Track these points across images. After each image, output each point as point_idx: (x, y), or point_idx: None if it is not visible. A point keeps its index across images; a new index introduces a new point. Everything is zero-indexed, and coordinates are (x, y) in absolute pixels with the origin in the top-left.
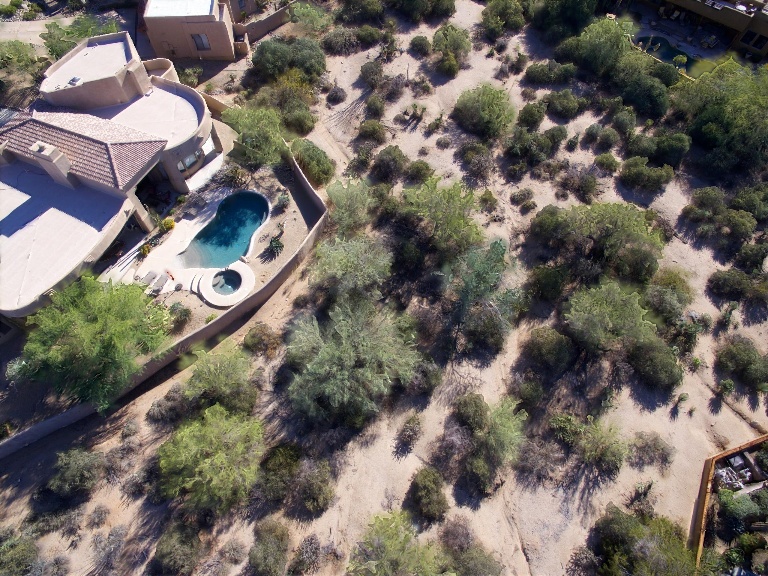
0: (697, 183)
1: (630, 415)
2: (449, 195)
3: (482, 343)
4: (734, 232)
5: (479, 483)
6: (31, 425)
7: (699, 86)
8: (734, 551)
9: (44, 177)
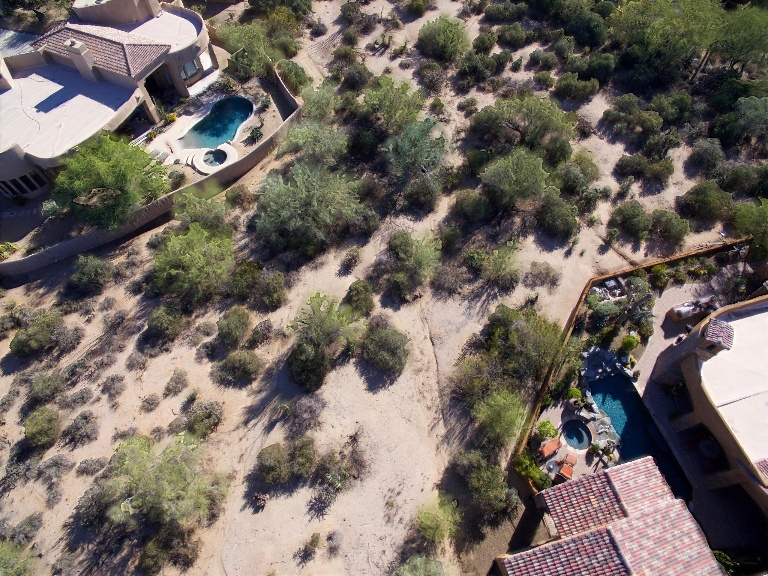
0: None
1: (531, 254)
2: (396, 90)
3: (417, 204)
4: (645, 130)
5: (401, 293)
6: None
7: (626, 14)
8: (594, 337)
9: (74, 74)
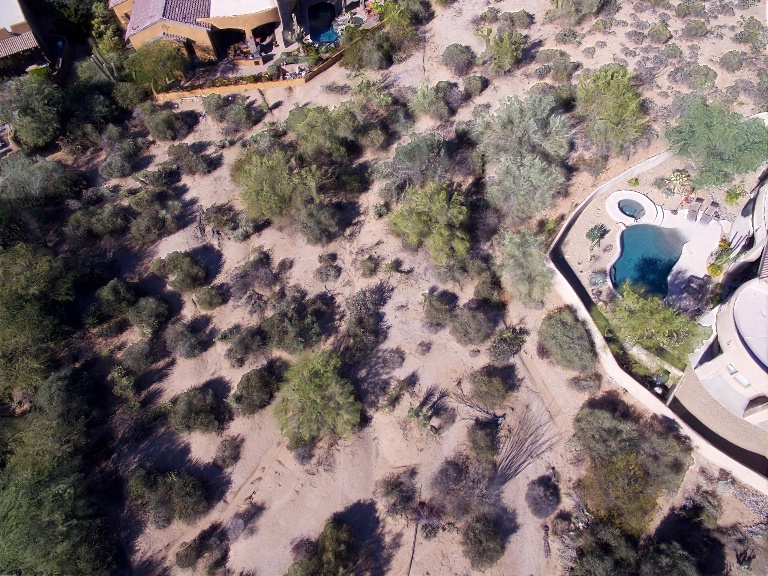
0: (129, 264)
1: None
2: (428, 214)
3: None
4: None
5: None
6: None
7: None
8: None
9: None
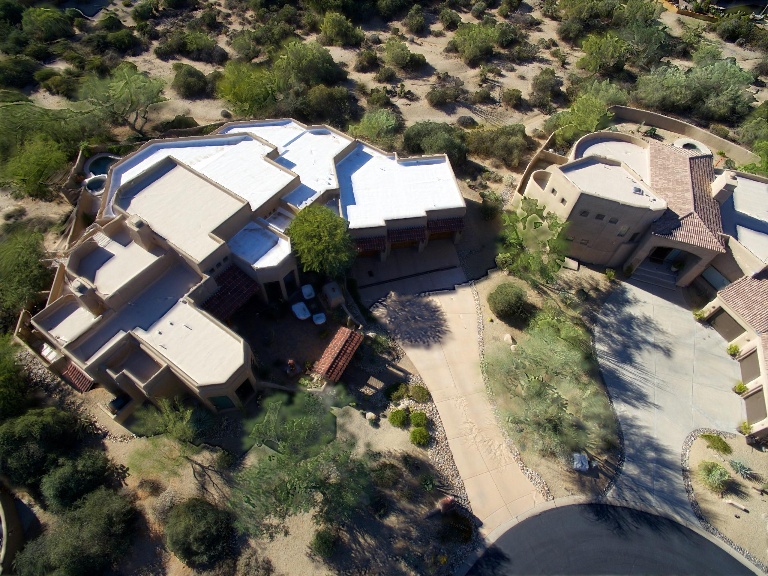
0: None
1: None
2: None
3: None
4: None
5: None
6: None
7: None
8: None
9: None
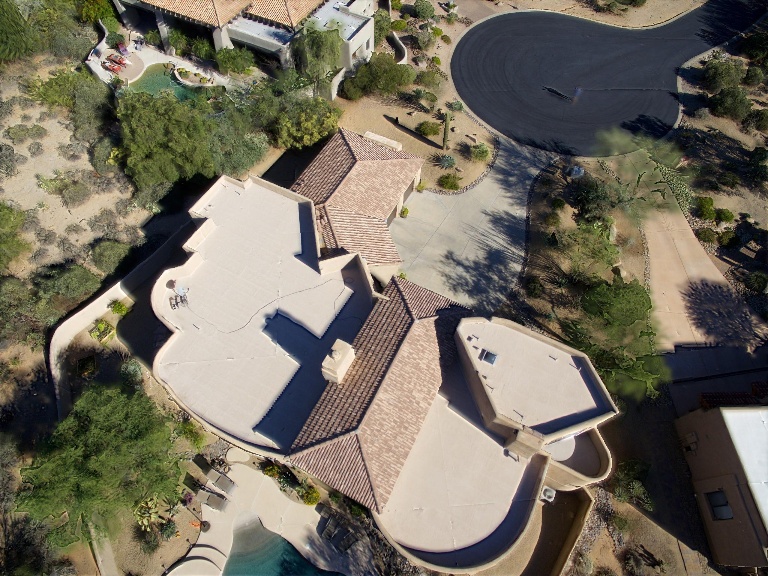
0: None
1: None
2: None
3: None
4: None
5: None
6: (87, 390)
7: None
8: None
9: None
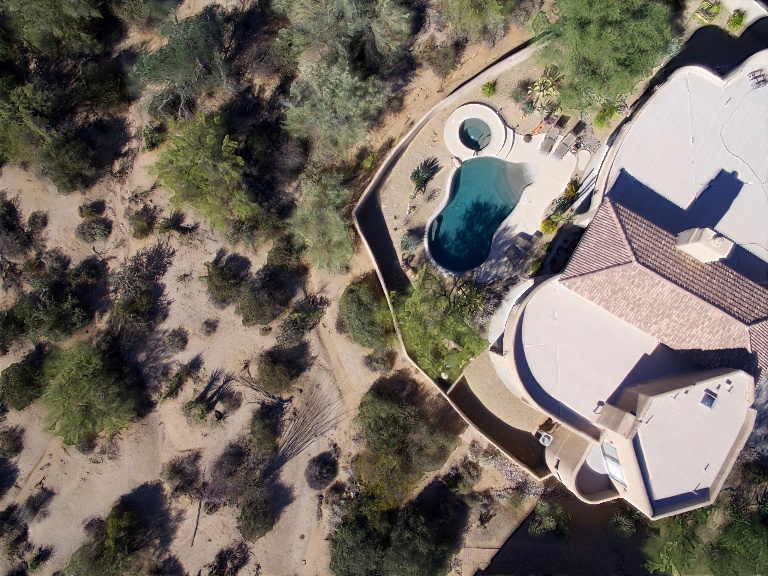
0: None
1: None
2: (190, 171)
3: None
4: None
5: None
6: None
7: None
8: None
9: None
